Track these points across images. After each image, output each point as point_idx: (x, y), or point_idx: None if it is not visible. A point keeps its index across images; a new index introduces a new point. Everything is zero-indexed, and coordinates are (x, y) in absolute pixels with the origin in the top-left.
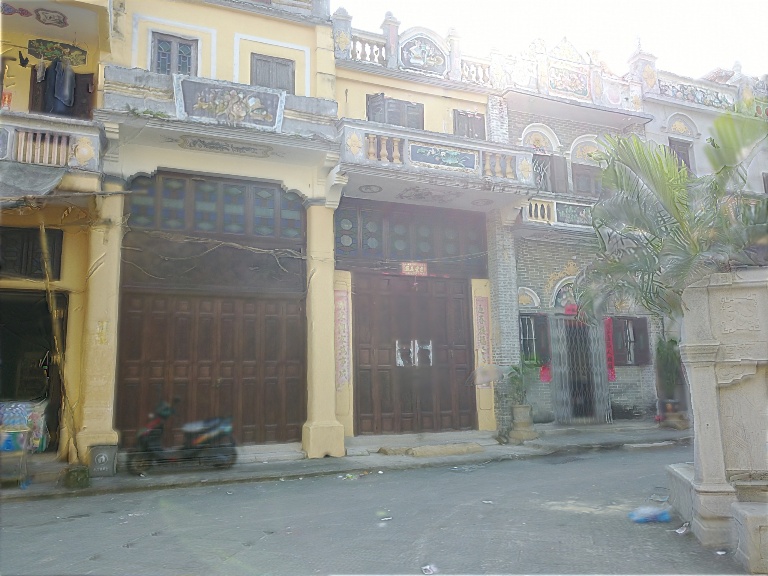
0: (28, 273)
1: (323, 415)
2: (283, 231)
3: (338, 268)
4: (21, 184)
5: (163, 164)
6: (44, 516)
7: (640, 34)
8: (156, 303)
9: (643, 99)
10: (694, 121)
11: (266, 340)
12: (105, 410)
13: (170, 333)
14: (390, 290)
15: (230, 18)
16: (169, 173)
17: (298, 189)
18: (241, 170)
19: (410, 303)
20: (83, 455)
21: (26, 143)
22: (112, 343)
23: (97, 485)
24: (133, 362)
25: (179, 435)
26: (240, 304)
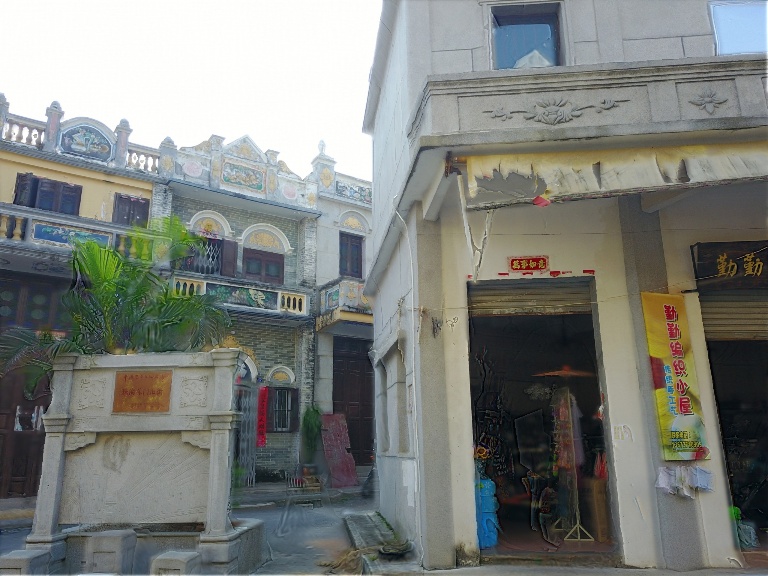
0: None
1: None
2: None
3: None
4: None
5: None
6: None
7: (323, 141)
8: None
9: (318, 197)
10: (367, 219)
11: None
12: None
13: None
14: None
15: None
16: None
17: None
18: None
19: (40, 370)
20: None
21: None
22: None
23: None
24: None
25: None
26: None
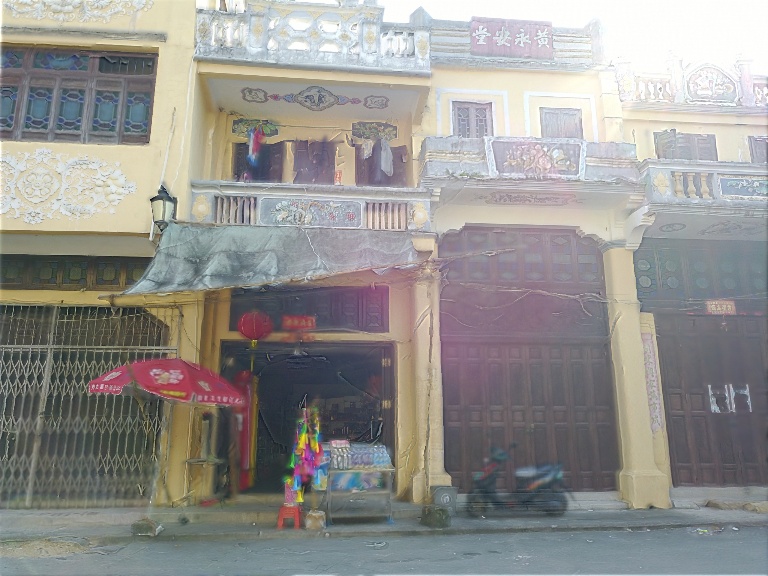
0: (364, 326)
1: (644, 463)
2: (581, 276)
3: (640, 310)
4: (382, 249)
5: (470, 220)
6: (439, 551)
7: None
8: (470, 350)
9: None
10: None
11: (574, 385)
12: (440, 452)
13: (485, 379)
14: (696, 331)
15: (518, 78)
16: (474, 228)
17: (595, 233)
18: (539, 219)
19: (720, 344)
20: (428, 494)
21: (374, 212)
22: (440, 389)
23: (456, 524)
24: (455, 407)
25: (500, 478)
26: (546, 349)
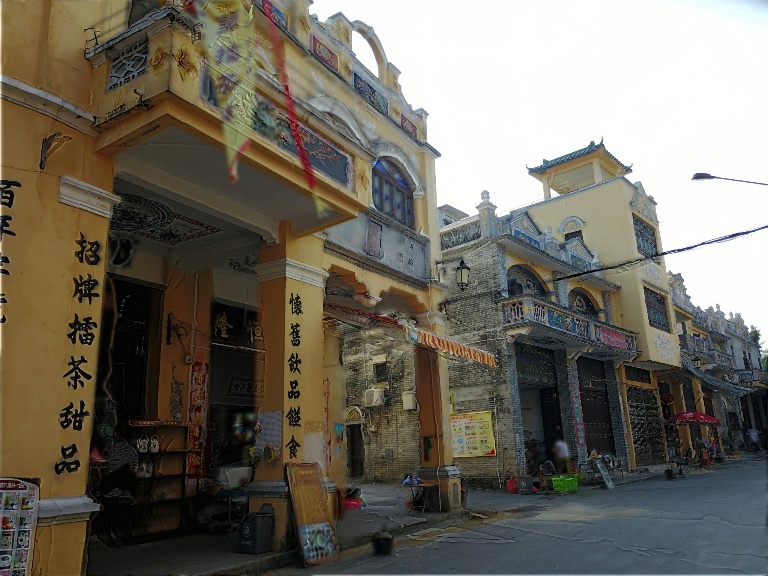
0: None
1: None
2: (689, 383)
3: None
4: None
5: None
6: None
7: None
8: None
9: (725, 331)
10: None
11: None
12: None
13: None
14: None
15: None
16: None
17: None
18: None
19: None
20: None
21: None
22: None
23: None
24: None
25: None
26: None
